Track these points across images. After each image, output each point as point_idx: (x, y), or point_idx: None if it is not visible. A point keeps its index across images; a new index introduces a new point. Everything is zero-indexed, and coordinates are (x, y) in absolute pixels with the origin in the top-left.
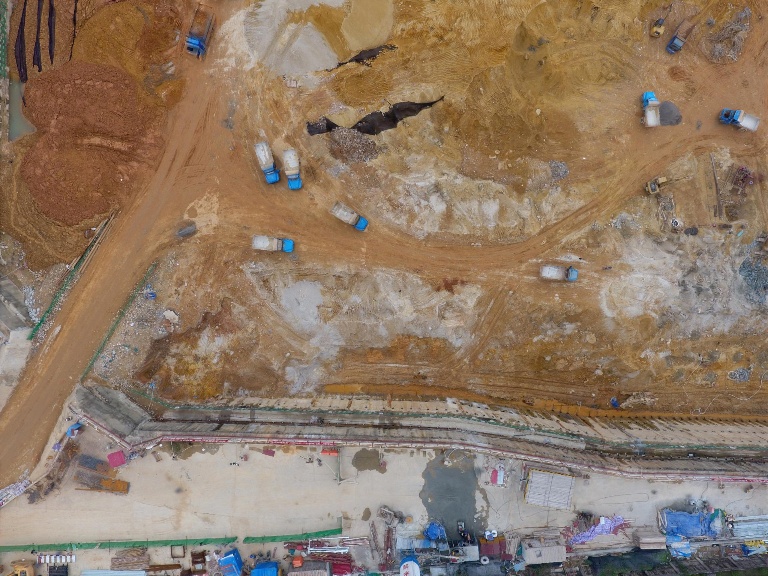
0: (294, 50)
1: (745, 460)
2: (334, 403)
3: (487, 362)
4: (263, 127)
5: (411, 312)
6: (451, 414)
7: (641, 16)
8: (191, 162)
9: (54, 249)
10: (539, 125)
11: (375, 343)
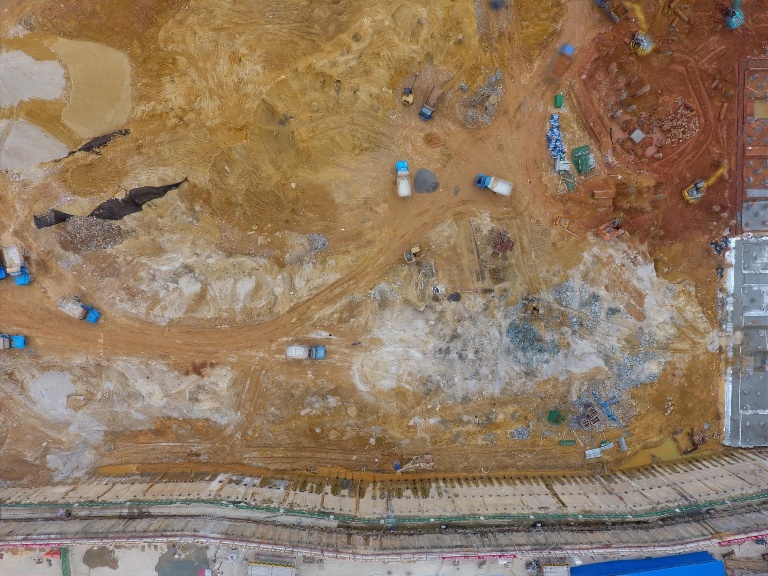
0: (8, 146)
1: (493, 530)
2: (91, 491)
3: (257, 437)
4: None
5: (161, 397)
6: (200, 500)
7: (392, 84)
8: None
9: None
10: (296, 198)
11: (138, 426)
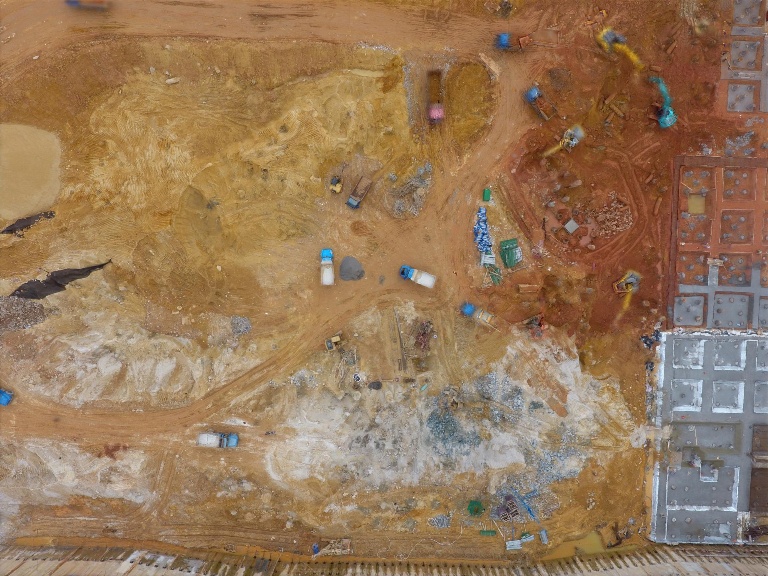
0: None
1: None
2: None
3: (173, 516)
4: None
5: (72, 478)
6: None
7: (321, 172)
8: None
9: None
10: (222, 280)
11: (52, 502)
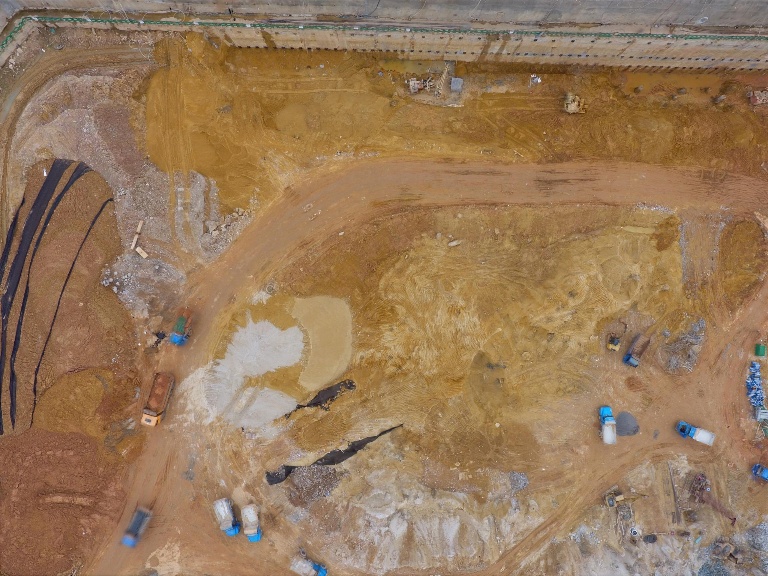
0: (251, 412)
1: None
2: None
3: None
4: (223, 477)
5: None
6: None
7: (597, 330)
8: (152, 513)
9: None
10: (499, 436)
11: None
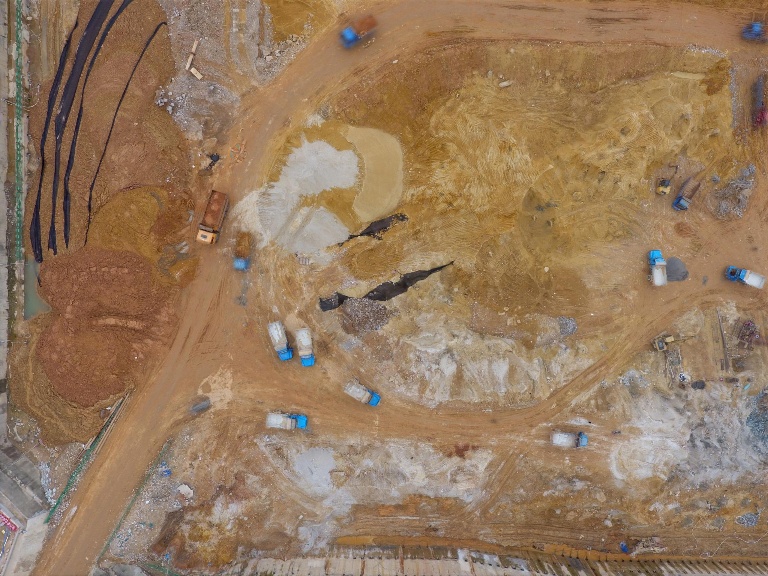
0: (306, 233)
1: None
2: (347, 567)
3: (498, 515)
4: (276, 303)
5: (423, 478)
6: None
7: (647, 174)
8: (205, 339)
9: (70, 430)
10: (547, 281)
11: (387, 501)
